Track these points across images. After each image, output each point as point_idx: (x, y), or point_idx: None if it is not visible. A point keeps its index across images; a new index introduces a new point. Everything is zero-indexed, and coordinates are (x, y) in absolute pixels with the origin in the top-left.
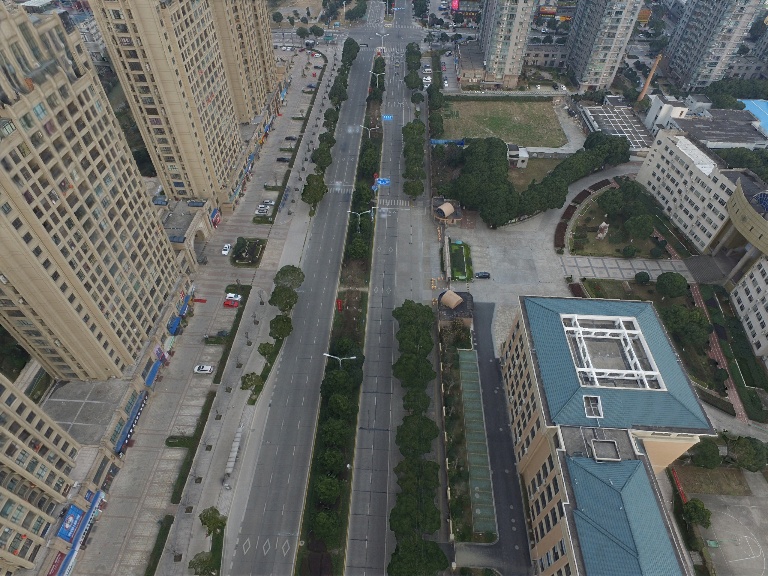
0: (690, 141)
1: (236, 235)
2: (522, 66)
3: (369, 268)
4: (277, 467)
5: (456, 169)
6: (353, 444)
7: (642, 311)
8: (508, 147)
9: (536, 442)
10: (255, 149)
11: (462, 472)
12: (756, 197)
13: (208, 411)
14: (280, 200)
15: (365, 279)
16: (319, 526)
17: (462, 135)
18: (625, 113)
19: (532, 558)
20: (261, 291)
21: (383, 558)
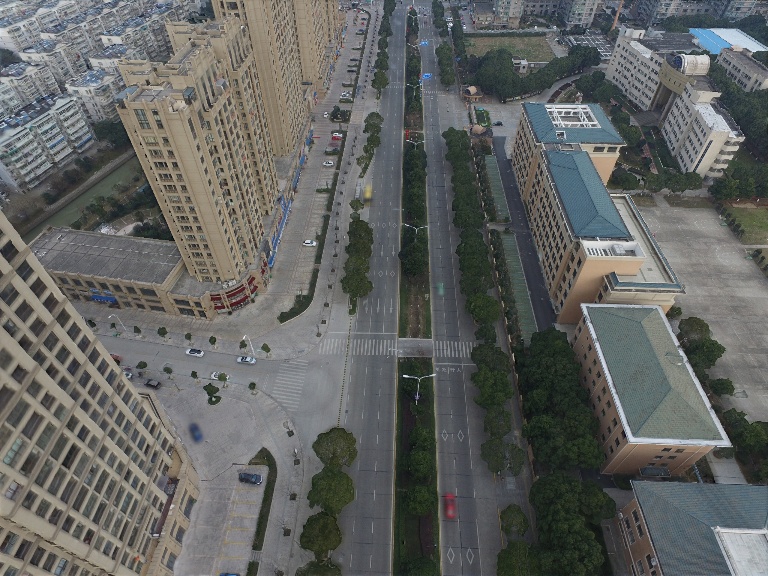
0: (640, 43)
1: (330, 109)
2: (523, 15)
3: (422, 122)
4: (383, 200)
5: (476, 72)
6: (425, 191)
7: (592, 105)
8: (513, 58)
9: (531, 165)
10: (332, 63)
11: (490, 198)
12: (673, 61)
13: (337, 180)
14: (355, 91)
15: (420, 127)
16: (414, 206)
17: (479, 56)
18: (600, 39)
19: (530, 226)
20: (357, 128)
21: (448, 228)
